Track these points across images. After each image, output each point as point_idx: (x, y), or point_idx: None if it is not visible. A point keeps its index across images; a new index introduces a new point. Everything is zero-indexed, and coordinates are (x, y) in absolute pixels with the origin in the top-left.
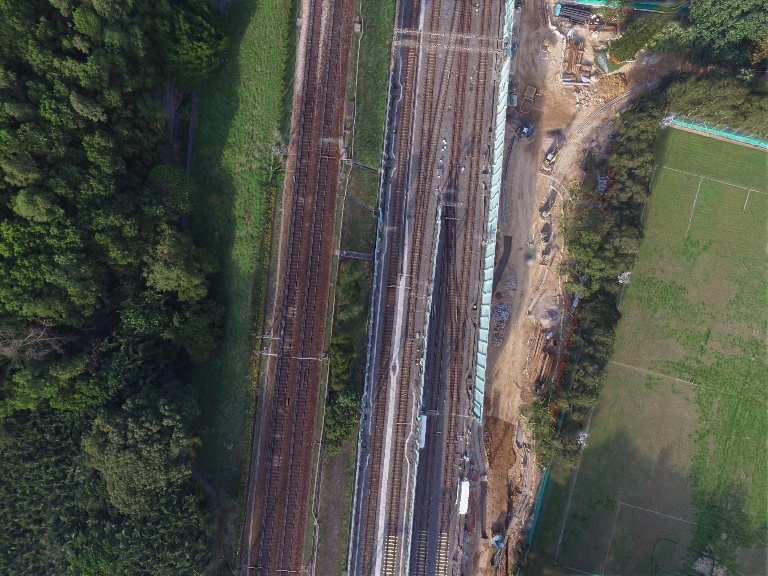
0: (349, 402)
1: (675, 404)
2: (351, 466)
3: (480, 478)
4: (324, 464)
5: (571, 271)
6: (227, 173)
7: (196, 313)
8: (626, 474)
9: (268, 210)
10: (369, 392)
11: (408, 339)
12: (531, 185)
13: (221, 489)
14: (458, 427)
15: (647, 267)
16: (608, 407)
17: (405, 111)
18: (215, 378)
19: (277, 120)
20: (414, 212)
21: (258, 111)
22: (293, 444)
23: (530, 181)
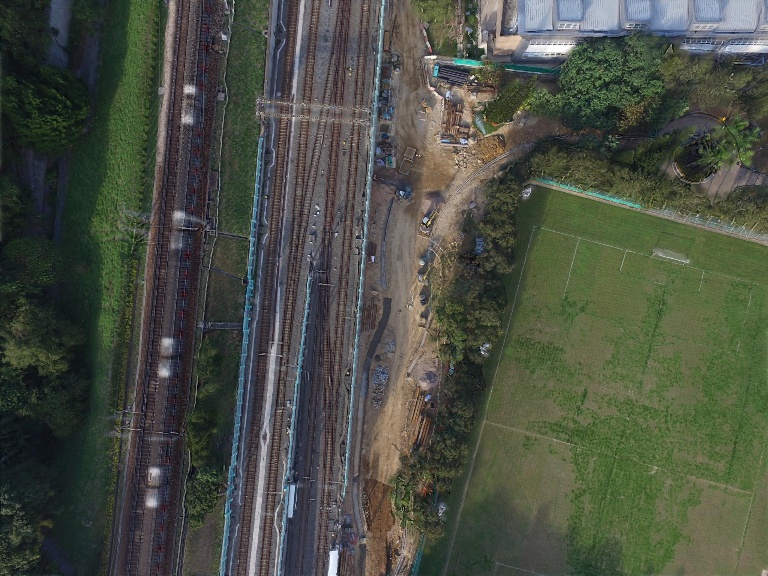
0: (209, 478)
1: (552, 464)
2: (219, 537)
3: (359, 541)
4: (187, 538)
5: (447, 334)
6: (95, 241)
7: (54, 389)
8: (503, 535)
9: (129, 283)
10: (239, 461)
11: (279, 407)
12: (410, 247)
13: (79, 567)
14: (331, 493)
15: (525, 328)
16: (486, 468)
17: (278, 176)
18: (78, 452)
19: (139, 191)
20: (286, 279)
21: (122, 181)
22: (155, 519)
23: (409, 243)
